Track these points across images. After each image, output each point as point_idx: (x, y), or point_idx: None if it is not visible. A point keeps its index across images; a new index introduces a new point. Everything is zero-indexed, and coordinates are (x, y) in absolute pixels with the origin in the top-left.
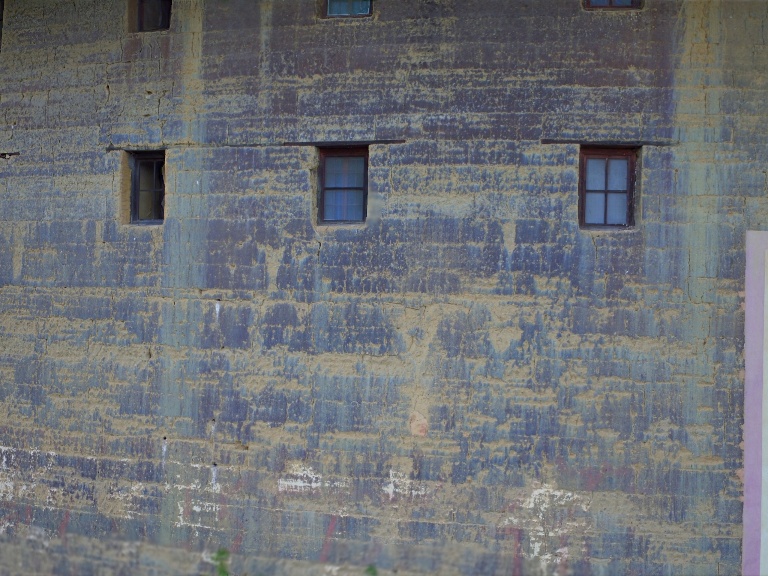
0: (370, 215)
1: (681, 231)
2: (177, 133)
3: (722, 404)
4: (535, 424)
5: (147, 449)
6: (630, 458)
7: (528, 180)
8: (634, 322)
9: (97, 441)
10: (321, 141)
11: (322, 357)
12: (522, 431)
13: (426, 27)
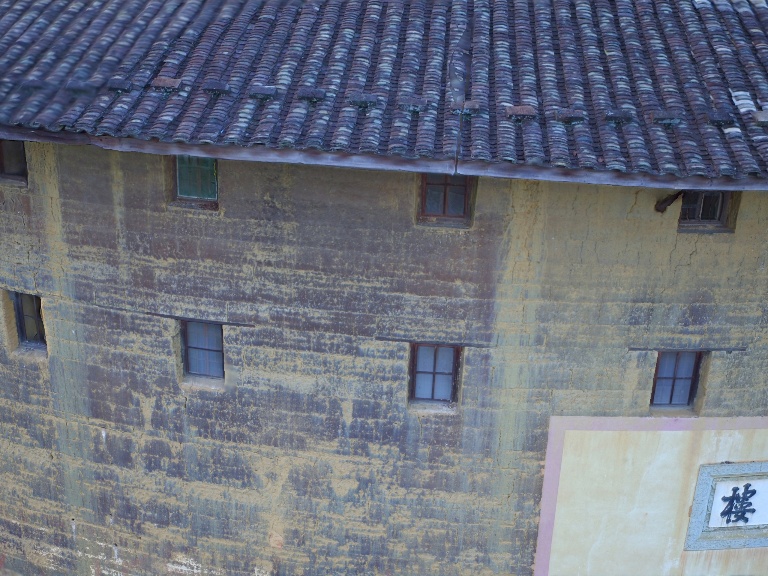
0: (227, 382)
1: (494, 415)
2: (49, 286)
3: (519, 539)
4: (369, 547)
5: (60, 525)
6: (444, 574)
7: (363, 369)
8: (451, 481)
9: (18, 512)
10: (180, 316)
11: (195, 484)
12: (358, 551)
13: (269, 229)
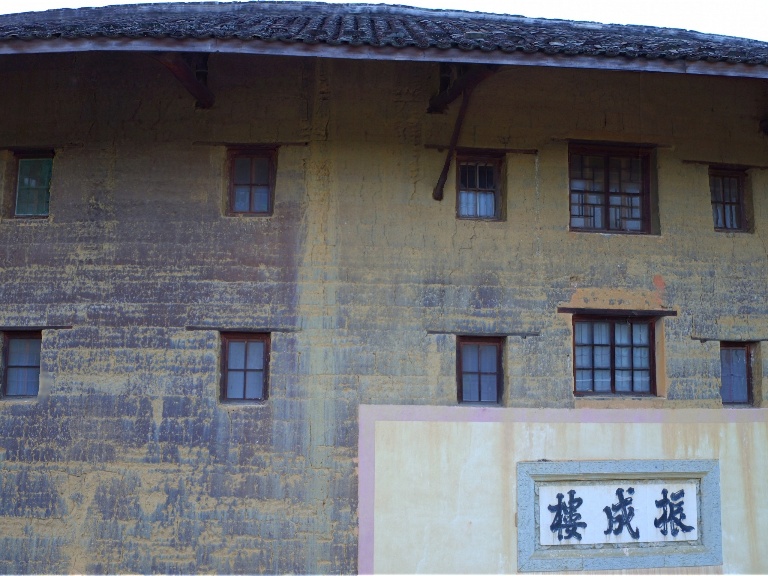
0: (41, 392)
1: (303, 405)
2: None
3: (339, 558)
4: None
5: None
6: None
7: (174, 362)
8: (263, 486)
9: None
10: (2, 326)
11: None
12: None
13: (92, 229)
